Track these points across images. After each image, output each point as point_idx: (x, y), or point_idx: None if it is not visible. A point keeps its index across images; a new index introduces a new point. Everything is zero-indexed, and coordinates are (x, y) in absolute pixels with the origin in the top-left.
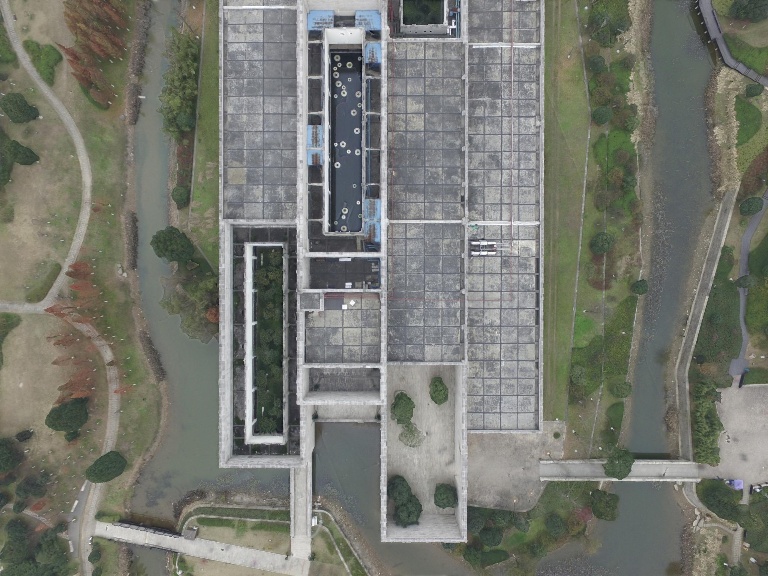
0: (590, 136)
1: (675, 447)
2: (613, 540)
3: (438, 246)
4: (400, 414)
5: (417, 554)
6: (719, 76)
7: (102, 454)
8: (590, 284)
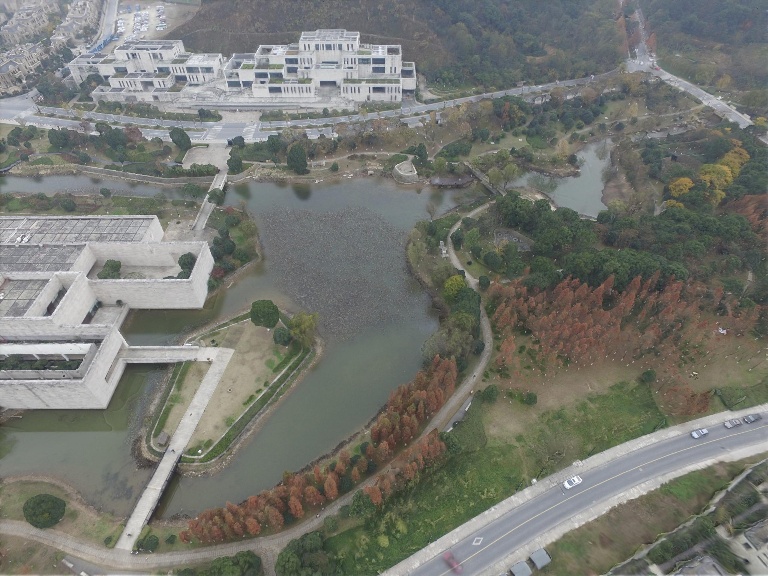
0: (3, 212)
1: (209, 184)
2: (257, 205)
3: (1, 257)
4: (106, 275)
5: (242, 290)
6: (13, 173)
7: (42, 542)
8: (93, 212)
